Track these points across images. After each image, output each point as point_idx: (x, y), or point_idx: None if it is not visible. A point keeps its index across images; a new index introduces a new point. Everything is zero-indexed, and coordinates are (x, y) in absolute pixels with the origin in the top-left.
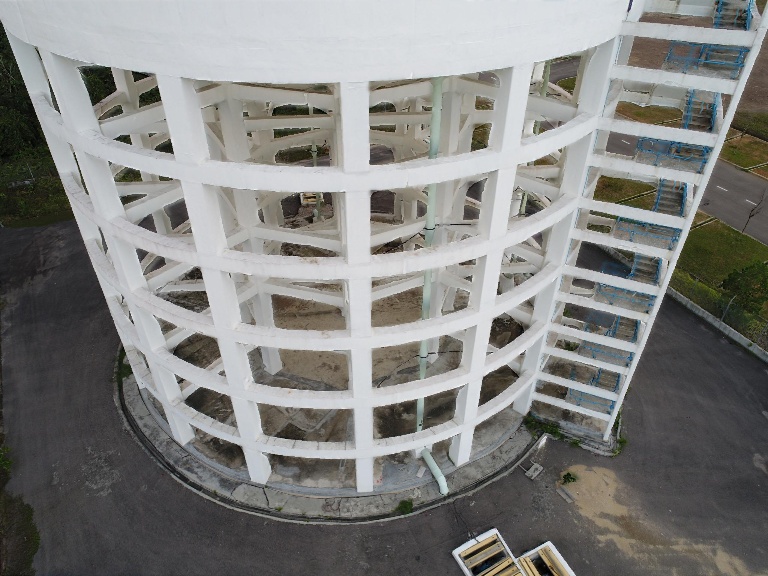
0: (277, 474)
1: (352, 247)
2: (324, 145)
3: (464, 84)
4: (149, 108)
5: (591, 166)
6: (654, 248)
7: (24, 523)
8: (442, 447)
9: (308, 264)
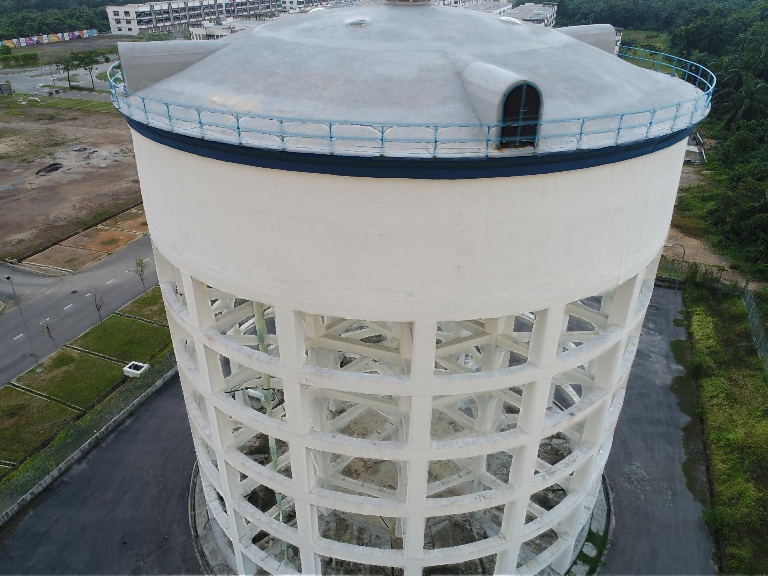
0: None
1: None
2: None
3: None
4: None
5: None
6: None
7: (692, 482)
8: None
9: None
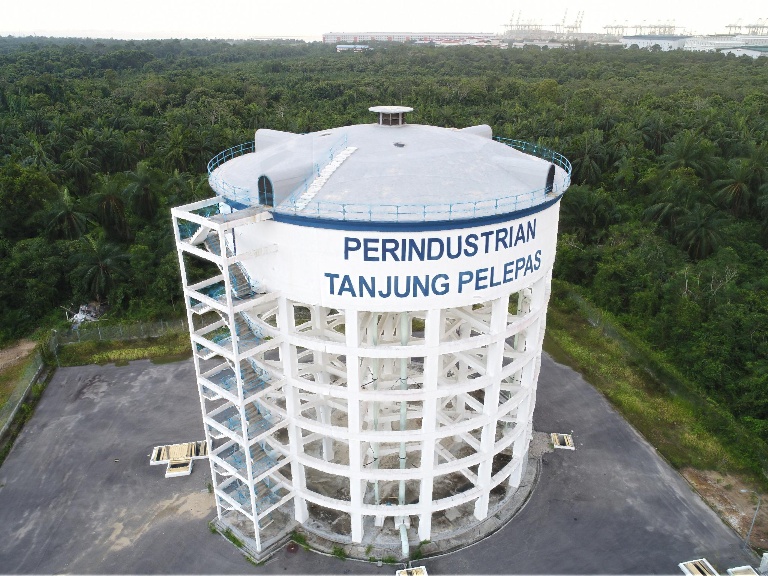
0: None
1: None
2: None
3: None
4: None
5: None
6: None
7: None
8: None
9: None
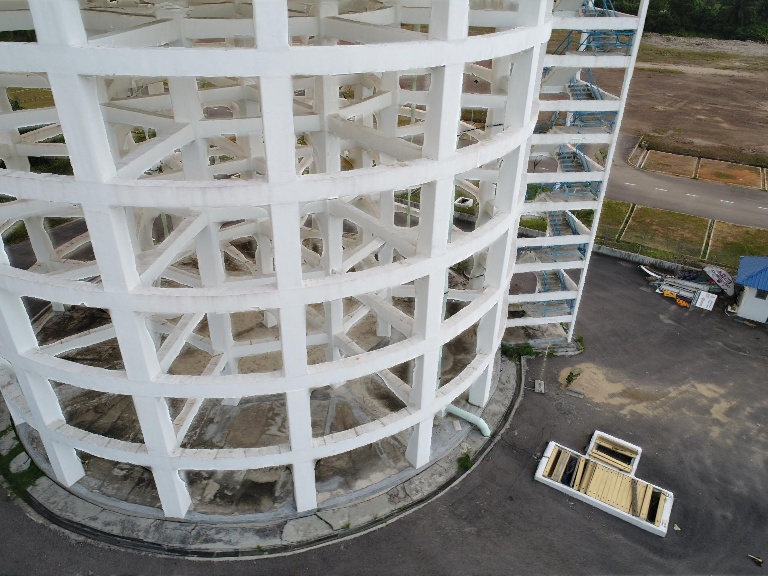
0: (321, 492)
1: (443, 137)
2: (158, 165)
3: (409, 12)
4: (122, 32)
5: (545, 67)
6: (598, 135)
7: None
8: (457, 398)
9: (401, 168)
